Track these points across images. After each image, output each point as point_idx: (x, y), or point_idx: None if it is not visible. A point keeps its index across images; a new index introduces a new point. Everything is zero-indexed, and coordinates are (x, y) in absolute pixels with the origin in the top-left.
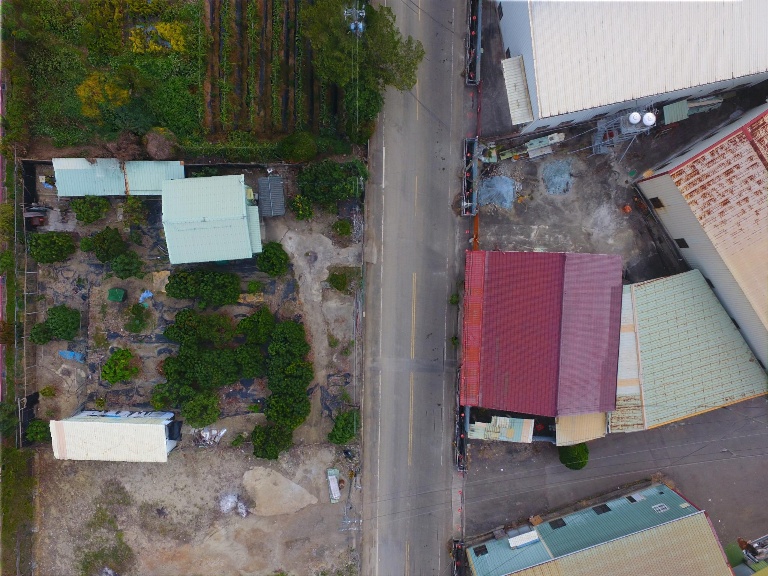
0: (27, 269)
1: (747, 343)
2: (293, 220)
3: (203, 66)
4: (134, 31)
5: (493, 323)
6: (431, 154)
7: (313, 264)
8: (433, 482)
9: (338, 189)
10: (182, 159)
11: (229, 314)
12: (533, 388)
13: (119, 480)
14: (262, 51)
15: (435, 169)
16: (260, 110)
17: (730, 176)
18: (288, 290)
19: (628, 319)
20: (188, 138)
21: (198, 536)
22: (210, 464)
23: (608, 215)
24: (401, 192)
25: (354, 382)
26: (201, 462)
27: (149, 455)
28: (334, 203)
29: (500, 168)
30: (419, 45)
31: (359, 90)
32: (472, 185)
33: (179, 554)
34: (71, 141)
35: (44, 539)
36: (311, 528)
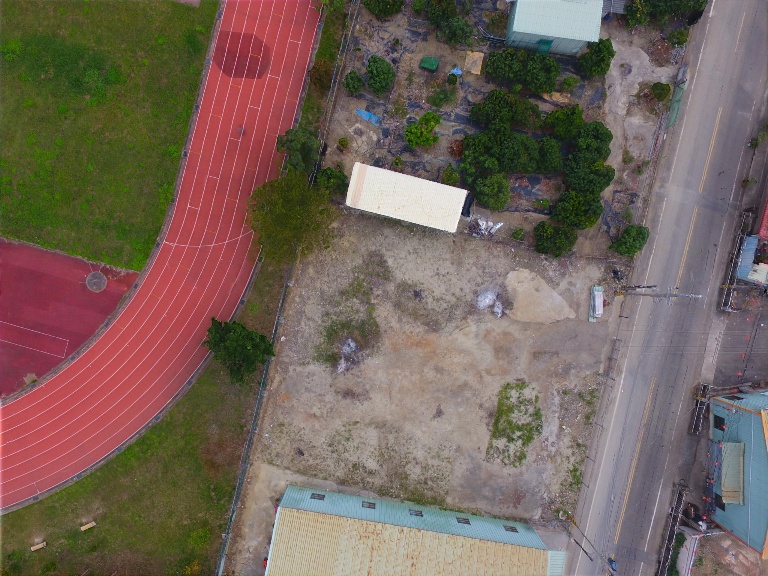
0: None
1: None
2: (616, 29)
3: None
4: None
5: None
6: None
7: (626, 77)
8: (692, 322)
9: None
10: None
11: None
12: None
13: (383, 253)
14: None
15: (764, 9)
16: None
17: None
18: (595, 97)
19: None
20: None
21: (448, 327)
22: (477, 256)
23: None
24: (726, 25)
25: (639, 203)
26: (468, 252)
27: (439, 221)
28: (670, 15)
29: None
30: None
31: None
32: None
33: (425, 341)
34: None
35: (295, 297)
36: (562, 343)
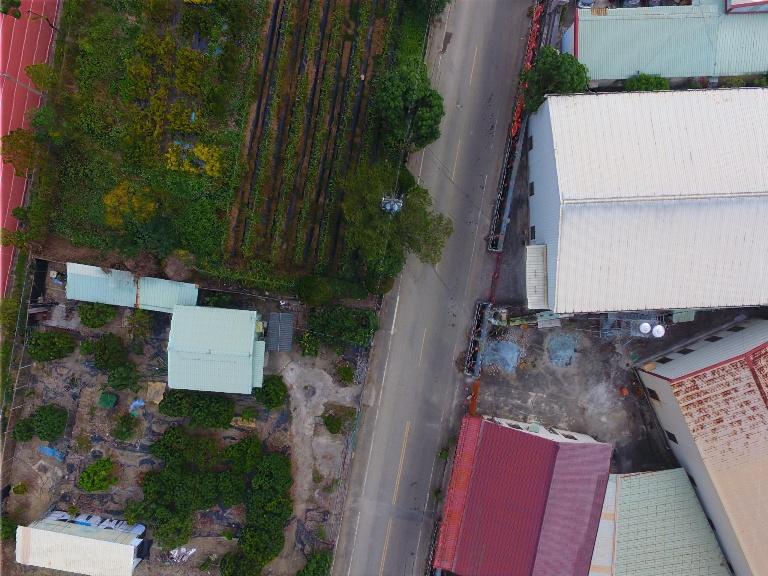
0: (21, 363)
1: (720, 546)
2: (298, 352)
3: (234, 195)
4: (171, 147)
5: (478, 493)
6: (443, 309)
7: (310, 398)
8: None
9: (347, 337)
10: (197, 278)
11: (218, 435)
12: (508, 567)
13: None
14: (294, 187)
15: (445, 324)
16: (283, 243)
17: (727, 397)
18: (281, 420)
19: (610, 507)
20: (207, 260)
21: None
22: None
23: (605, 393)
24: (408, 341)
25: (332, 520)
26: None
27: (113, 572)
28: (341, 346)
29: (508, 334)
30: (449, 222)
31: (384, 257)
32: (478, 344)
33: None
34: (89, 244)
35: None
36: None
